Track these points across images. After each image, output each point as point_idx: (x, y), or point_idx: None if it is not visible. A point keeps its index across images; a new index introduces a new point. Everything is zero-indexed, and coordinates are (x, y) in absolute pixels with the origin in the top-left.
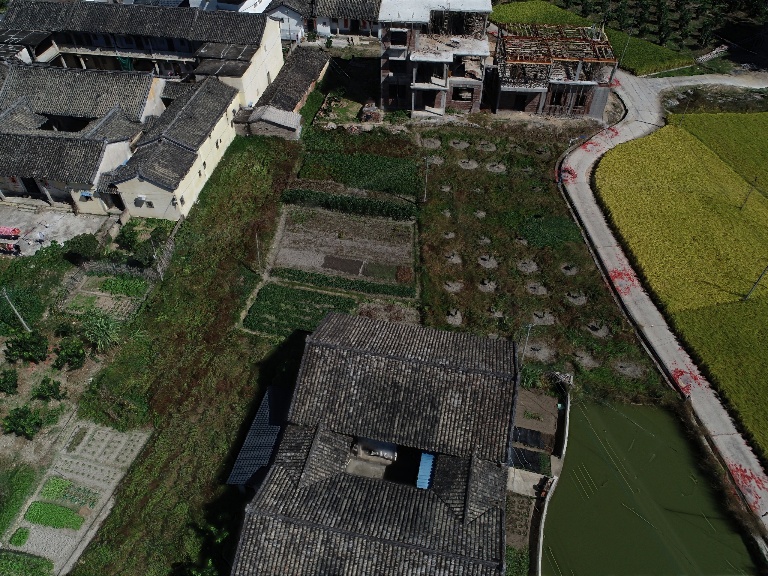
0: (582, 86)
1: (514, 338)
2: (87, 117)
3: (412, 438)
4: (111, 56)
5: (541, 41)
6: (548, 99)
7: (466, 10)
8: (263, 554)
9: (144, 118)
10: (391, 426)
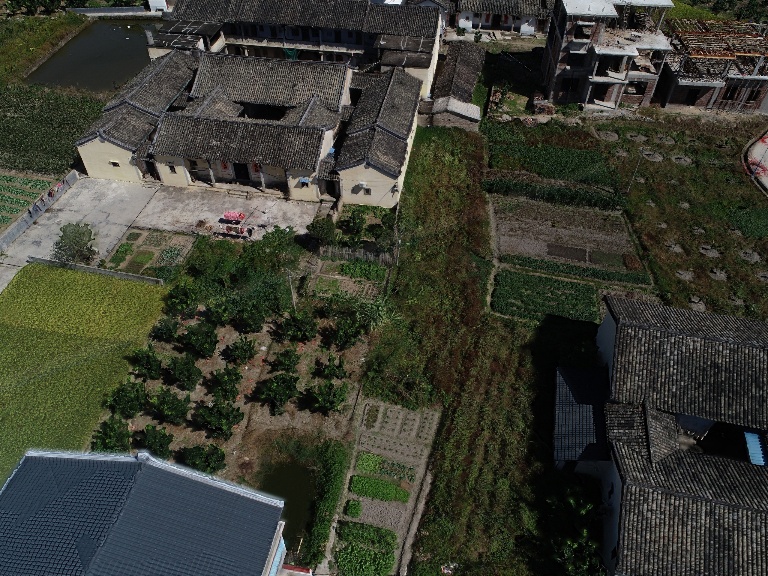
0: (760, 81)
1: None
2: (286, 106)
3: (742, 417)
4: (278, 47)
5: (716, 36)
6: (722, 94)
7: (648, 5)
8: (649, 524)
9: (341, 107)
10: (718, 405)
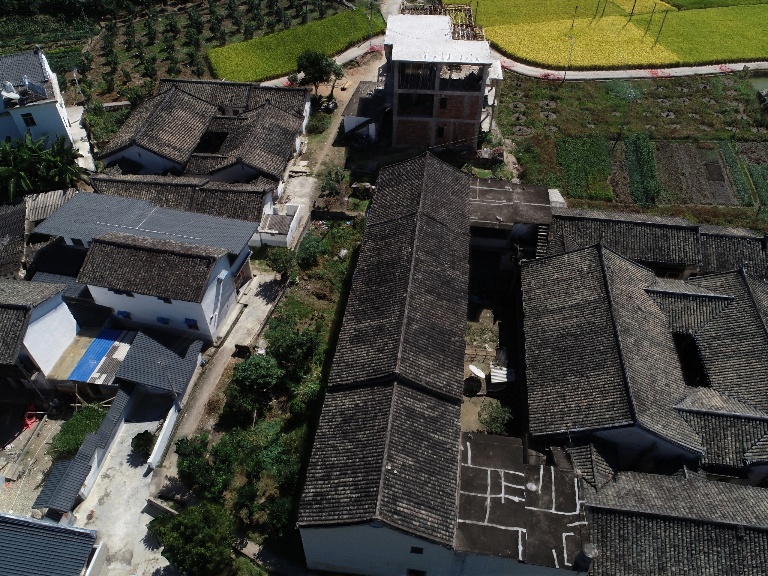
0: None
1: None
2: None
3: None
4: None
5: None
6: None
7: None
8: None
9: None
10: None
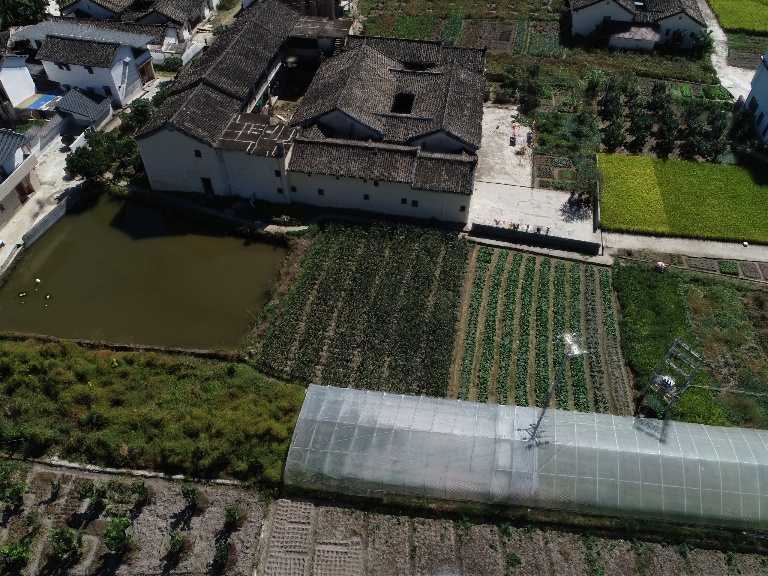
0: None
1: None
2: None
3: None
4: None
5: None
6: None
7: None
8: None
9: None
10: None
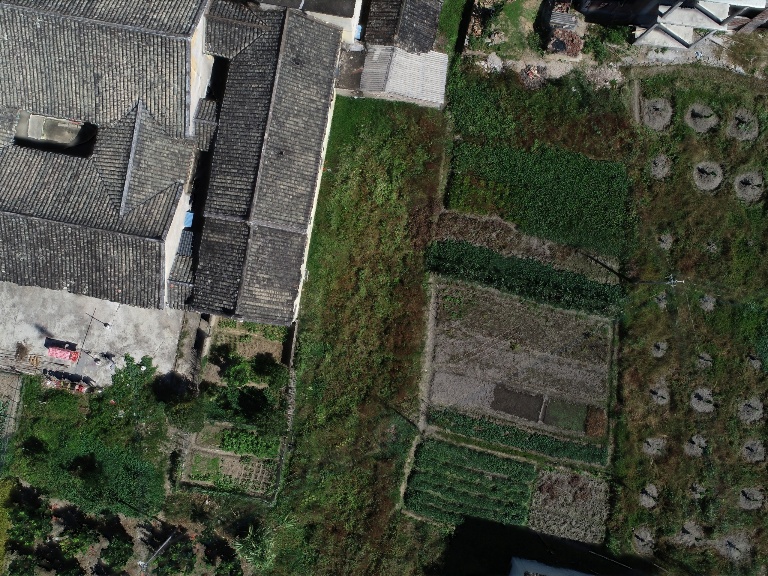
0: None
1: (714, 536)
2: (92, 123)
3: None
4: None
5: None
6: None
7: None
8: None
9: (192, 123)
10: None
